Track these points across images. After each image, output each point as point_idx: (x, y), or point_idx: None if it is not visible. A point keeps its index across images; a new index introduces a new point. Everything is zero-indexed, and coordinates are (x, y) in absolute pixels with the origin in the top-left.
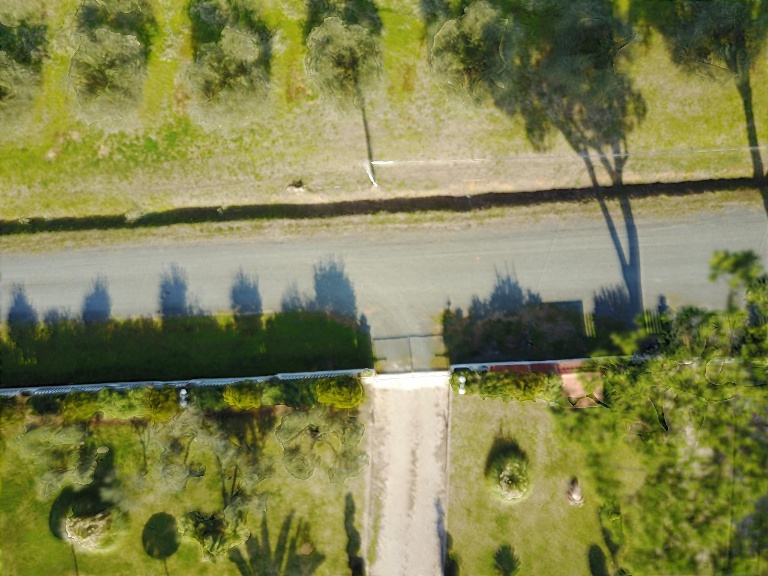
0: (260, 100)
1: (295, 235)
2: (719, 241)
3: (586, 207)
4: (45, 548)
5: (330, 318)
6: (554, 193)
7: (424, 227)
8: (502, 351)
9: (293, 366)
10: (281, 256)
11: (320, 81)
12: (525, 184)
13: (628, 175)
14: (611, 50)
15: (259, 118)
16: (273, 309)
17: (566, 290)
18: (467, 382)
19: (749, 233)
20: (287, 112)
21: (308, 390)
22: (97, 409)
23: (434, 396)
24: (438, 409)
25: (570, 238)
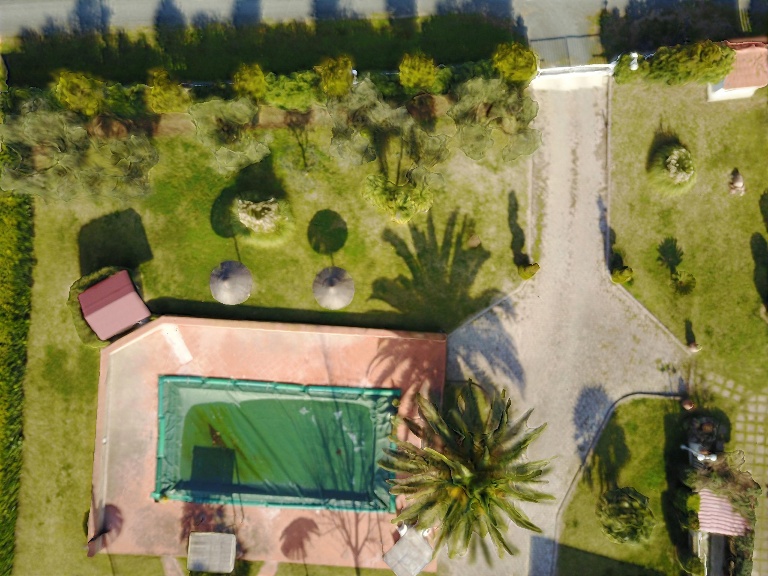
0: None
1: None
2: None
3: None
4: (207, 247)
5: (487, 20)
6: None
7: None
8: None
9: None
10: None
11: None
12: None
13: None
14: None
15: None
16: (429, 12)
17: None
18: (637, 61)
19: None
20: None
21: (482, 67)
22: (266, 92)
23: (592, 96)
24: (596, 109)
25: None
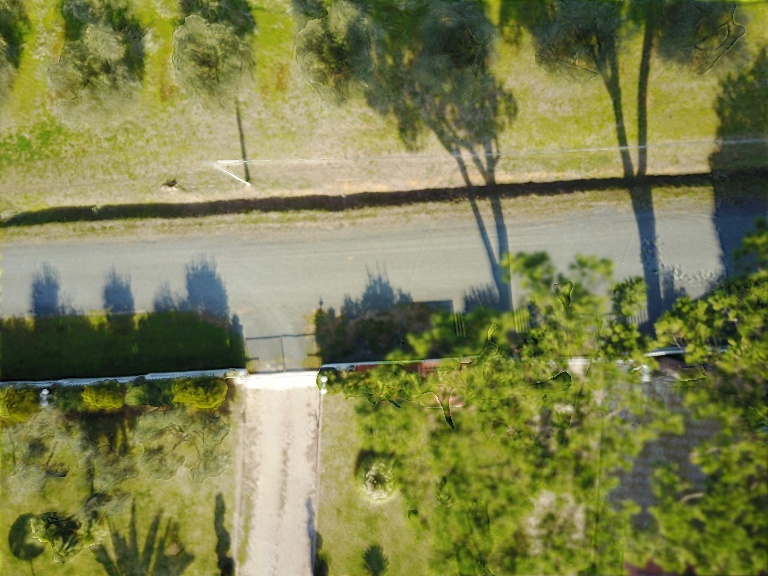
0: (124, 99)
1: (168, 234)
2: (587, 241)
3: (457, 207)
4: None
5: (202, 318)
6: (428, 193)
7: (297, 226)
8: (374, 351)
9: (165, 366)
10: (154, 255)
11: (183, 80)
12: (399, 183)
13: (500, 175)
14: (473, 50)
15: (133, 117)
16: (146, 308)
17: (437, 290)
18: (330, 382)
19: (617, 233)
20: (161, 111)
21: (169, 390)
22: None
23: (306, 396)
24: (310, 409)
25: (441, 238)
